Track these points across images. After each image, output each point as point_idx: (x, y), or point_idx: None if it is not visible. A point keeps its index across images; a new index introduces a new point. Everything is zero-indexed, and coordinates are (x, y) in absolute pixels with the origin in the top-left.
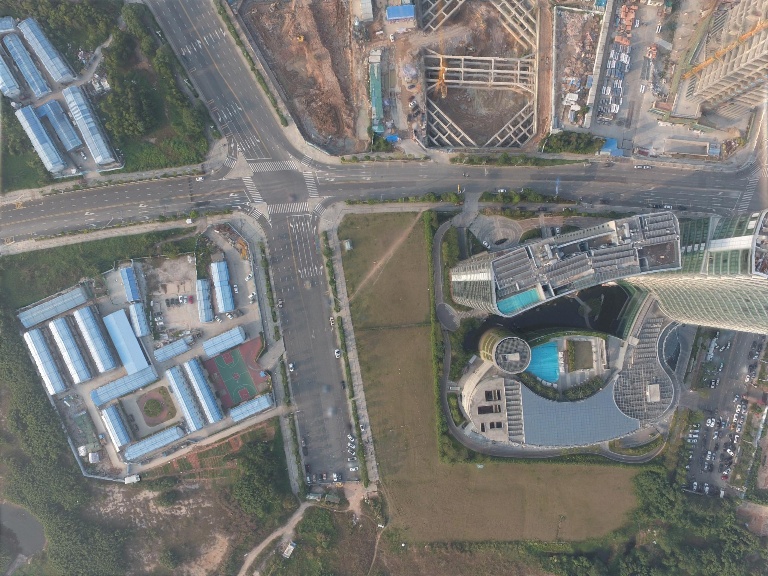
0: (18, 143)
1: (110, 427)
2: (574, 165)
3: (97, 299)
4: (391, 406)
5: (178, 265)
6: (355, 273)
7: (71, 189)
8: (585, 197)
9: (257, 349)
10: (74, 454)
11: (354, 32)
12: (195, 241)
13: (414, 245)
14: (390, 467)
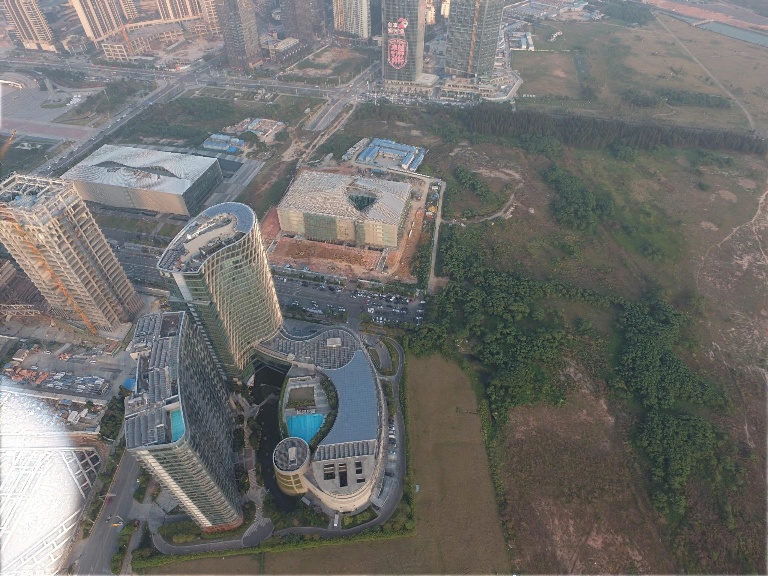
0: None
1: None
2: None
3: None
4: None
5: None
6: None
7: None
8: None
9: None
10: None
11: None
12: None
13: None
14: None
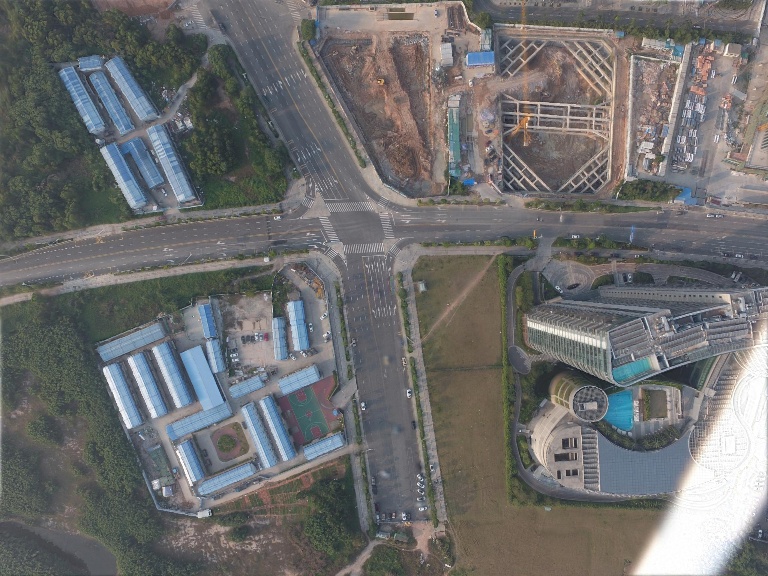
0: (102, 179)
1: (185, 462)
2: (647, 212)
3: (174, 334)
4: (461, 447)
5: (254, 302)
6: (428, 314)
7: (151, 225)
8: (657, 244)
9: (330, 387)
10: (148, 487)
11: (433, 76)
12: (272, 279)
13: (487, 288)
14: (458, 507)
